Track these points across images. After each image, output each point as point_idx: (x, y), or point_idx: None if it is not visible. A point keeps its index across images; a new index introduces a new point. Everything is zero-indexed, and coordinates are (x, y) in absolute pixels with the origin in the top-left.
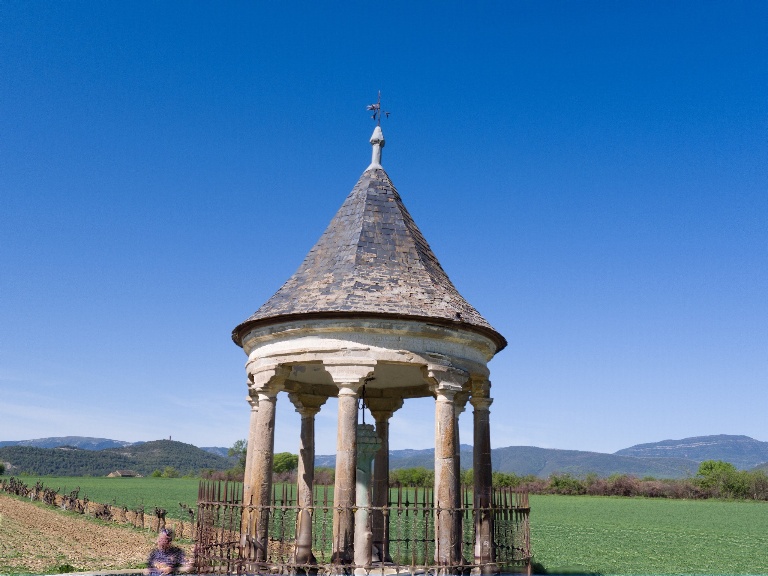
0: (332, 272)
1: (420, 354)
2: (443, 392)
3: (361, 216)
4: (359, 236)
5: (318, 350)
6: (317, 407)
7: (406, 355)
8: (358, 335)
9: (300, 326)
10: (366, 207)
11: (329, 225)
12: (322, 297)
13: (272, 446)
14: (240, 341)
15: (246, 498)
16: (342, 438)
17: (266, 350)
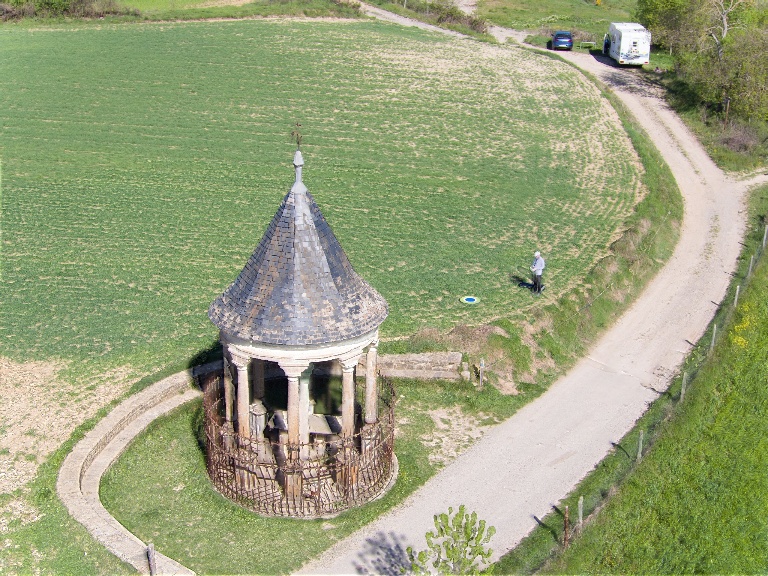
0: (327, 299)
1: None
2: None
3: (320, 245)
4: (328, 265)
5: None
6: None
7: None
8: (355, 340)
9: (330, 345)
10: (319, 235)
11: (296, 250)
12: (339, 325)
13: None
14: None
15: (246, 420)
16: (350, 393)
17: (296, 354)
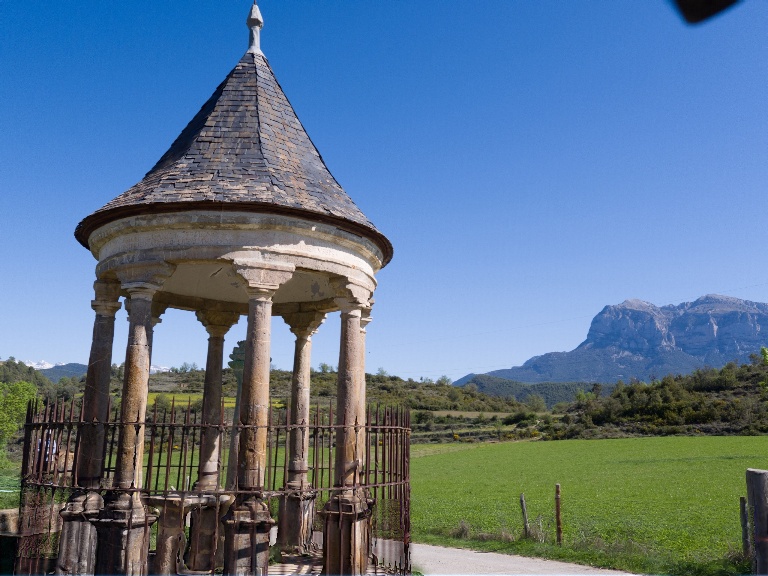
0: None
1: None
2: None
3: None
4: None
5: None
6: None
7: None
8: None
9: None
10: None
11: None
12: None
13: None
14: (317, 219)
15: None
16: None
17: None
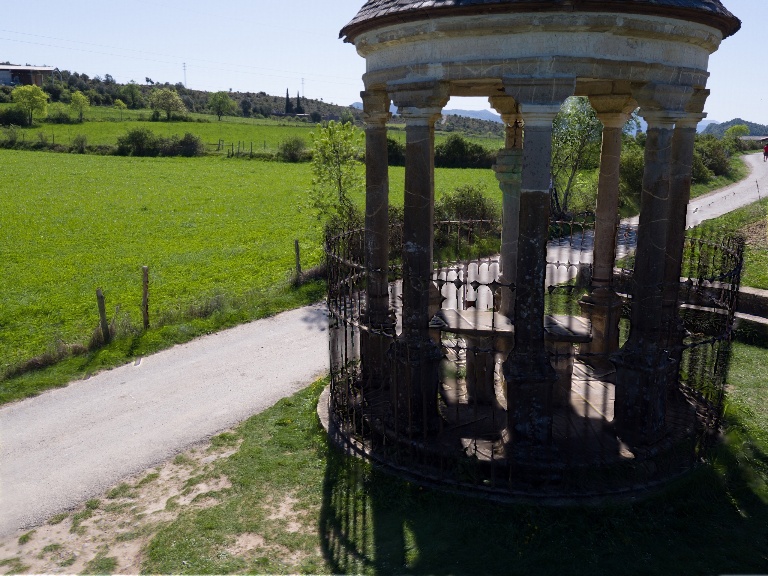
0: None
1: None
2: None
3: None
4: None
5: None
6: None
7: None
8: None
9: None
10: None
11: None
12: None
13: None
14: None
15: None
16: None
17: None
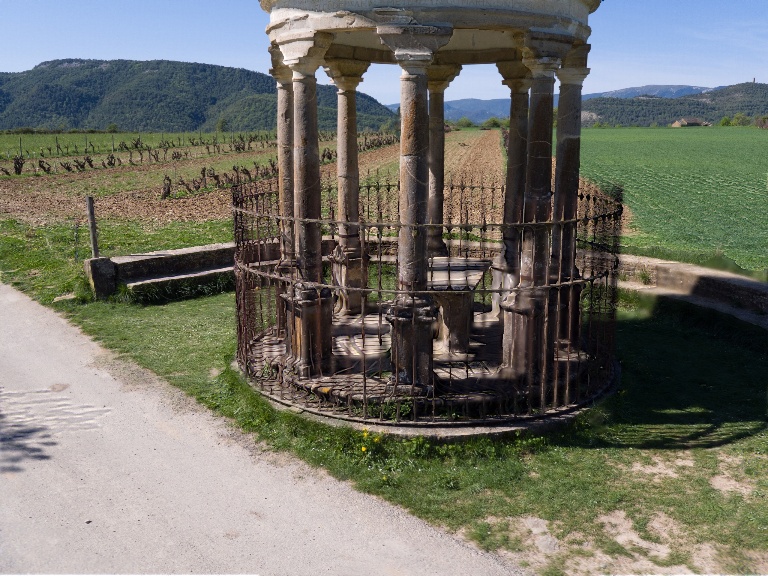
0: None
1: (363, 13)
2: (402, 64)
3: None
4: None
5: (274, 25)
6: (441, 80)
7: (346, 18)
8: None
9: None
10: None
11: None
12: None
13: (292, 139)
14: None
15: (338, 187)
16: None
17: None
